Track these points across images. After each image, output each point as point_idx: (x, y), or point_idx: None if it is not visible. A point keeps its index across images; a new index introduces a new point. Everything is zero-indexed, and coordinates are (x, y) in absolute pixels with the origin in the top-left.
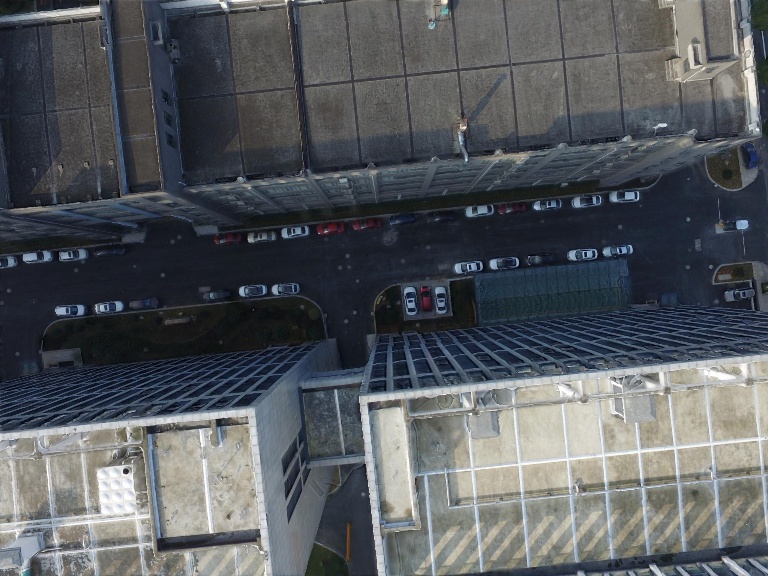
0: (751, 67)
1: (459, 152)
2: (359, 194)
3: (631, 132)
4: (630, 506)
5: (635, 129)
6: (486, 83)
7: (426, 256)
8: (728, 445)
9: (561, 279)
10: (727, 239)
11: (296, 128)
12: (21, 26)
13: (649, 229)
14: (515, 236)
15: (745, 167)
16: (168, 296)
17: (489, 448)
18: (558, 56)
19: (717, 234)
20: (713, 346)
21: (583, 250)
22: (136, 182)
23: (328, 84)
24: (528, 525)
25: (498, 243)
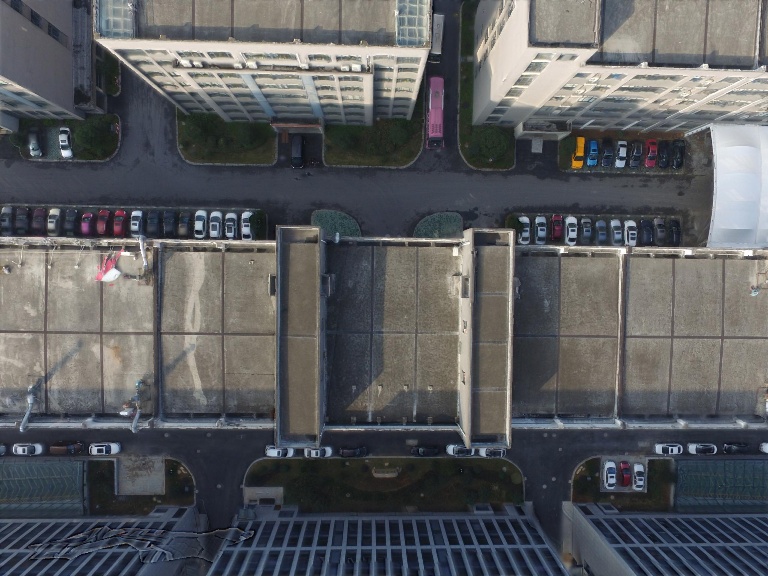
0: None
1: (764, 417)
2: None
3: None
4: None
5: None
6: None
7: (628, 432)
8: None
9: (757, 473)
10: None
11: (612, 375)
12: (356, 243)
13: None
14: None
15: None
16: (375, 445)
17: None
18: None
19: None
20: None
21: None
22: (479, 432)
23: (649, 337)
24: None
25: None
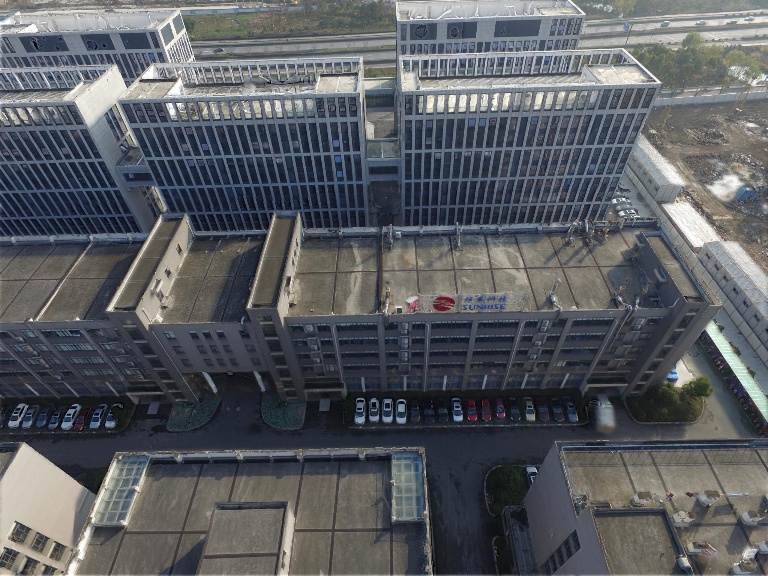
0: None
1: None
2: None
3: None
4: None
5: None
6: None
7: None
8: None
9: None
10: None
11: (82, 261)
12: None
13: None
14: None
15: None
16: None
17: None
18: None
19: None
20: None
21: None
22: (178, 222)
23: (45, 279)
24: None
25: None
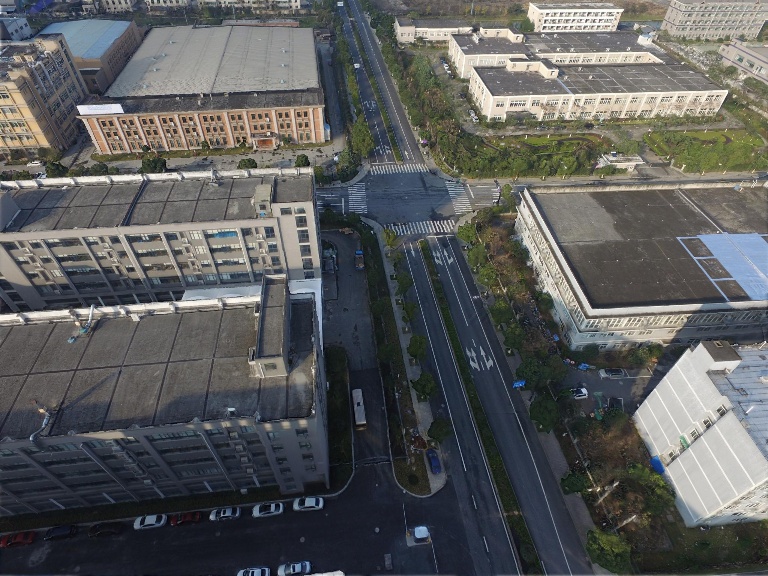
0: (312, 366)
1: None
2: None
3: (210, 417)
4: None
5: (214, 414)
6: (95, 379)
7: None
8: None
9: None
10: (420, 553)
11: None
12: None
13: (334, 542)
14: (183, 553)
15: (432, 472)
16: None
17: None
18: (164, 360)
19: (409, 547)
20: None
21: (252, 569)
22: None
23: None
24: None
25: (161, 562)
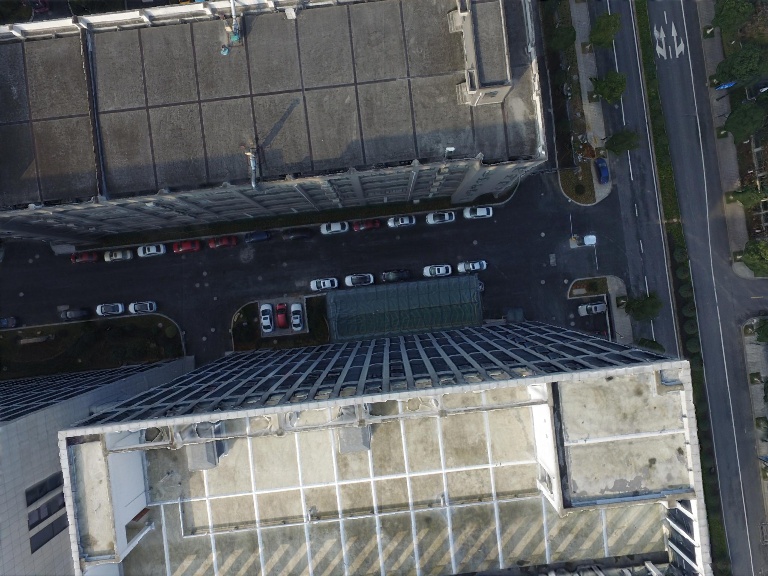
0: (536, 91)
1: None
2: (198, 214)
3: (424, 155)
4: (364, 533)
5: (428, 152)
6: (279, 108)
7: (283, 273)
8: (460, 472)
9: (412, 295)
10: (581, 254)
11: (92, 154)
12: None
13: (504, 244)
14: (371, 252)
15: (598, 182)
16: (27, 315)
17: (224, 477)
18: (350, 81)
19: (571, 249)
20: (441, 375)
21: (437, 266)
22: None
23: (123, 110)
24: (263, 553)
25: (354, 260)
